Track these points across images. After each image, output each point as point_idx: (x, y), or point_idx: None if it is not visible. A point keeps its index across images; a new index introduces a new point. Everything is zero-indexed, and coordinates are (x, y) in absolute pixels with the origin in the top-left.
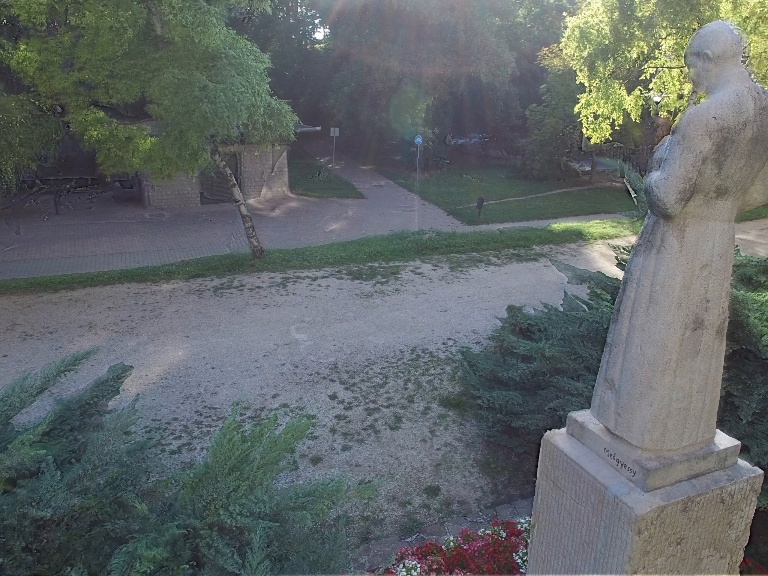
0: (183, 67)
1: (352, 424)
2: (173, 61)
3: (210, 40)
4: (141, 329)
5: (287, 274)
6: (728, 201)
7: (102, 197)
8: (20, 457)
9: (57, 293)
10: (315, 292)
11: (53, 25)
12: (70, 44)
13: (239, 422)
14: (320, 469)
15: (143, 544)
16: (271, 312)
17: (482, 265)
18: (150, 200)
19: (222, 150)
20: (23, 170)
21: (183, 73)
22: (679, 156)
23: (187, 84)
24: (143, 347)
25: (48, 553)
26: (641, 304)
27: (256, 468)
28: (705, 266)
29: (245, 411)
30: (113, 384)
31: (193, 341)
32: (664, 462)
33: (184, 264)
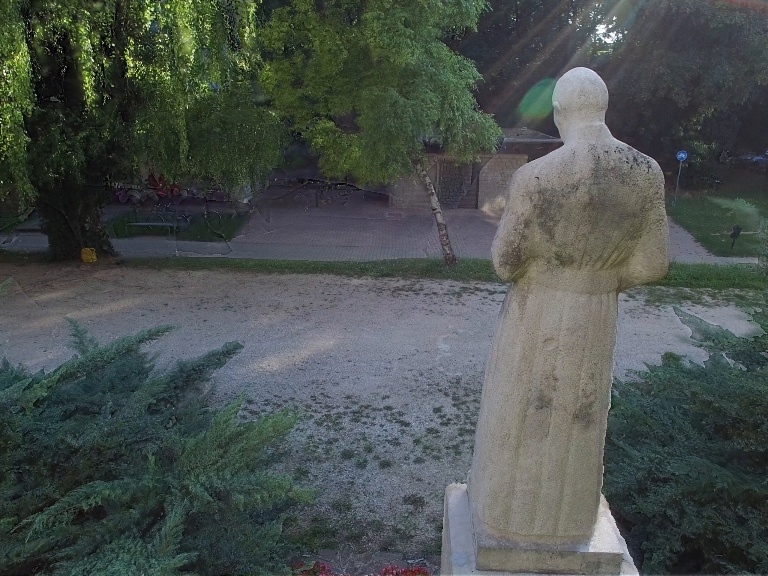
0: (389, 84)
1: (439, 440)
2: (383, 78)
3: (402, 60)
4: (313, 316)
5: (469, 284)
6: (583, 270)
7: (355, 194)
8: (34, 395)
9: (270, 275)
10: (485, 306)
11: (291, 49)
12: (302, 64)
13: (341, 414)
14: (383, 474)
15: (109, 484)
16: (432, 319)
17: (688, 303)
18: (393, 200)
19: (428, 160)
20: (259, 170)
21: (381, 90)
22: (505, 216)
23: (383, 100)
24: (306, 332)
25: (67, 473)
26: (491, 368)
27: (238, 450)
28: (551, 339)
29: (352, 405)
30: (220, 357)
31: (348, 334)
32: (503, 544)
33: (383, 263)
